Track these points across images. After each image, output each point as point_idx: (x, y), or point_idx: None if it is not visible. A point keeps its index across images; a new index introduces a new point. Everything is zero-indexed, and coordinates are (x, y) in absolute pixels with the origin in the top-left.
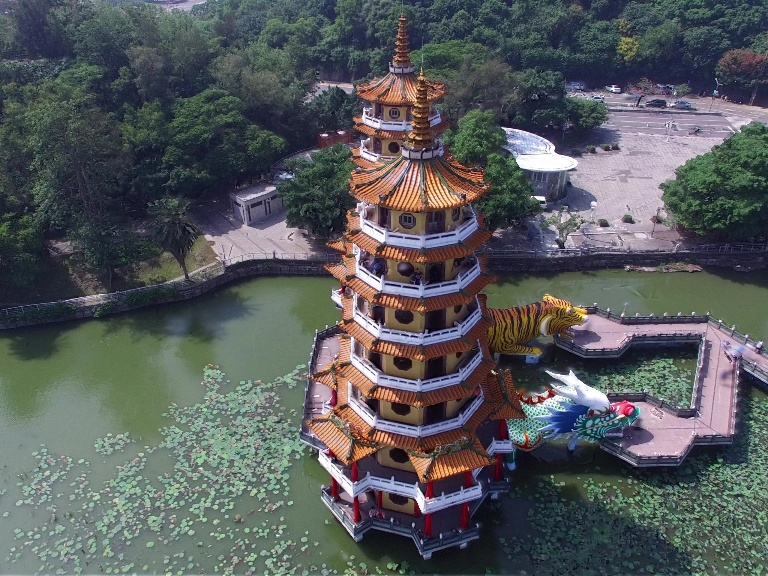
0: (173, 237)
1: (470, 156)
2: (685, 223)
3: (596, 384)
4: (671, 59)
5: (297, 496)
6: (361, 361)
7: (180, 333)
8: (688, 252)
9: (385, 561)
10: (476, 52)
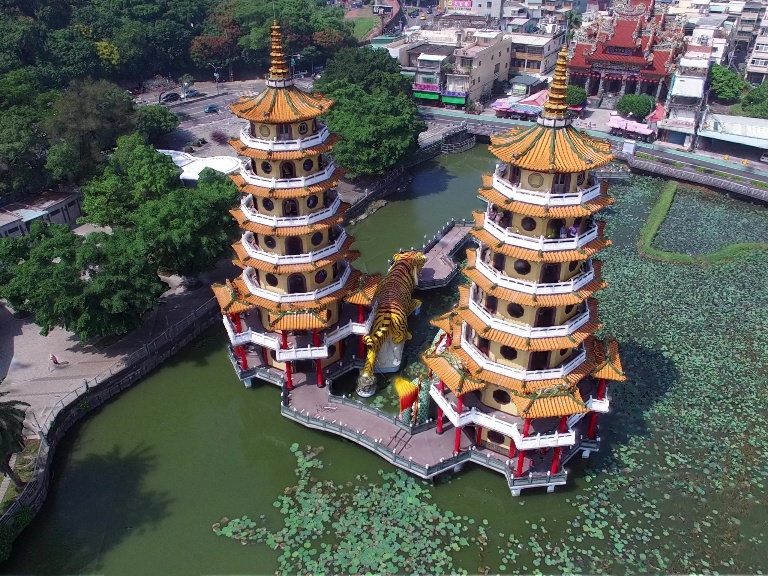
0: (11, 431)
1: (166, 183)
2: (368, 170)
3: None
4: (147, 55)
5: (476, 516)
6: (542, 329)
7: (112, 540)
8: (373, 192)
9: (580, 482)
10: (27, 81)
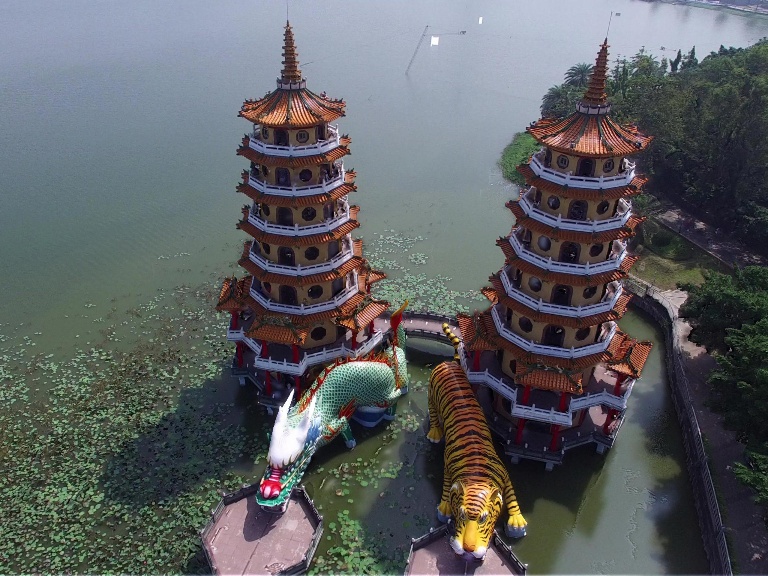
0: None
1: None
2: None
3: (377, 564)
4: None
5: None
6: None
7: None
8: None
9: None
10: None
